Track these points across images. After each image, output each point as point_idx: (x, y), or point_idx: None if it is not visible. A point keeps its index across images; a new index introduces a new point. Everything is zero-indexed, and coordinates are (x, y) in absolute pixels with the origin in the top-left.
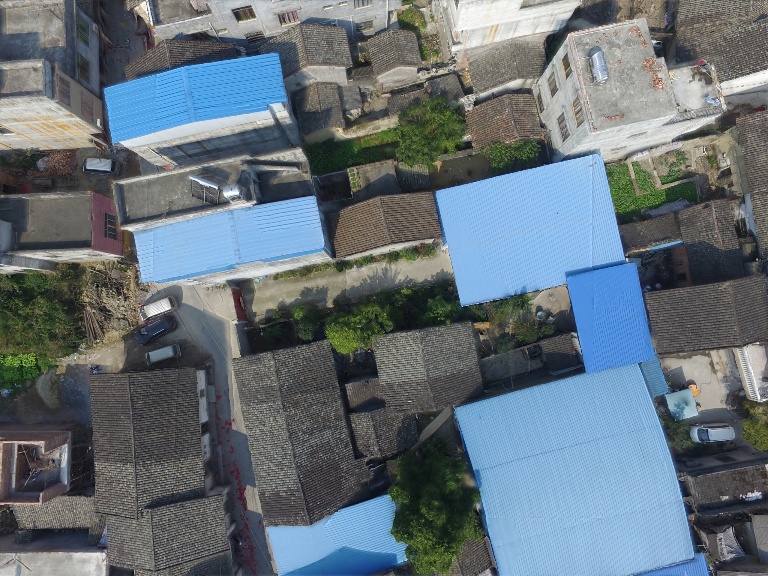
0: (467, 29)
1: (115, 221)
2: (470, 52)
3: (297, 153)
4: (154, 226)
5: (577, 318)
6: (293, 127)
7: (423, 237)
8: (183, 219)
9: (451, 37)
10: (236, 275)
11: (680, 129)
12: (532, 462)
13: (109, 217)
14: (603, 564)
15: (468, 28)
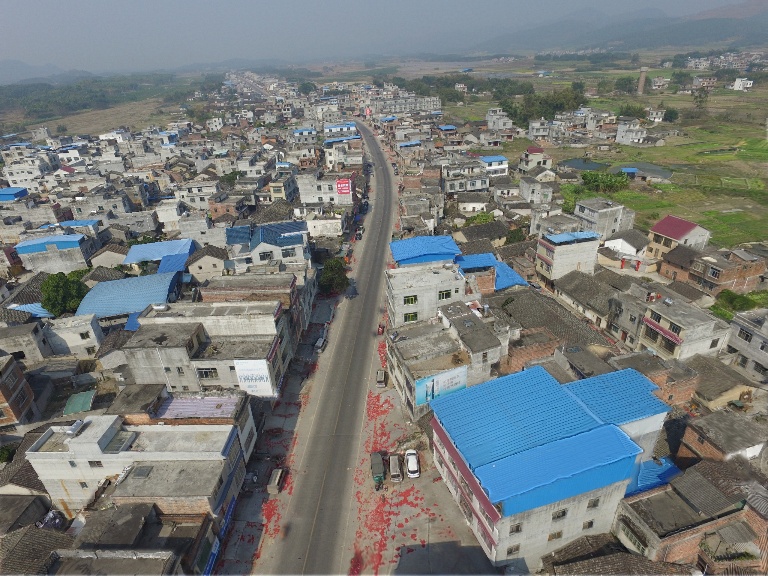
0: (164, 222)
1: (17, 257)
2: (170, 233)
3: (87, 230)
4: (29, 239)
5: (161, 263)
6: (98, 242)
7: (120, 253)
8: (39, 237)
9: (163, 228)
10: (47, 266)
11: (222, 235)
12: (116, 286)
13: (16, 253)
14: (124, 308)
15: (164, 221)
